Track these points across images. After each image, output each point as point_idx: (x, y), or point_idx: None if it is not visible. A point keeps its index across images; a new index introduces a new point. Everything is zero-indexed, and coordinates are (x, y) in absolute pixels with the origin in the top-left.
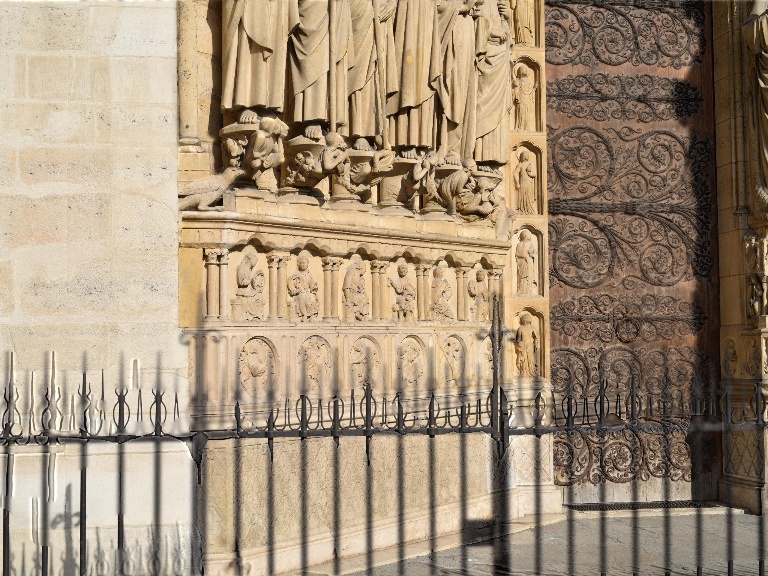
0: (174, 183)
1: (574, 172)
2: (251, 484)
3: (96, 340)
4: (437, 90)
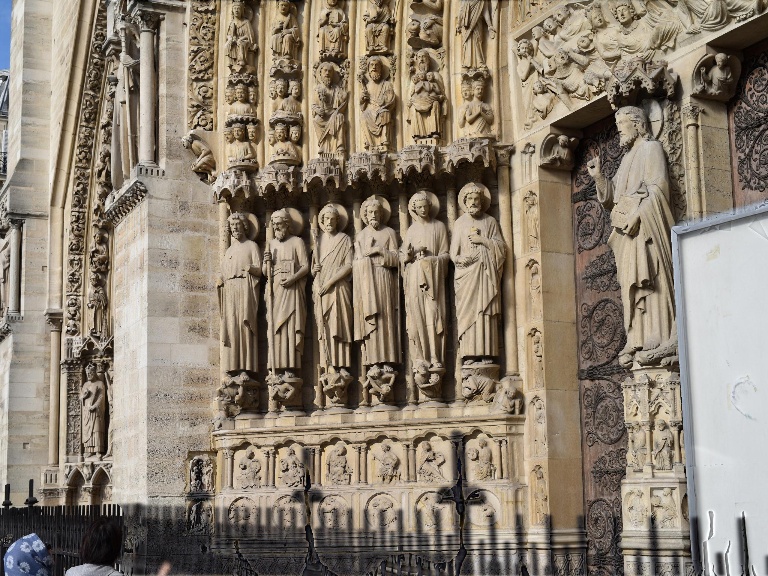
0: None
1: None
2: None
3: None
4: None
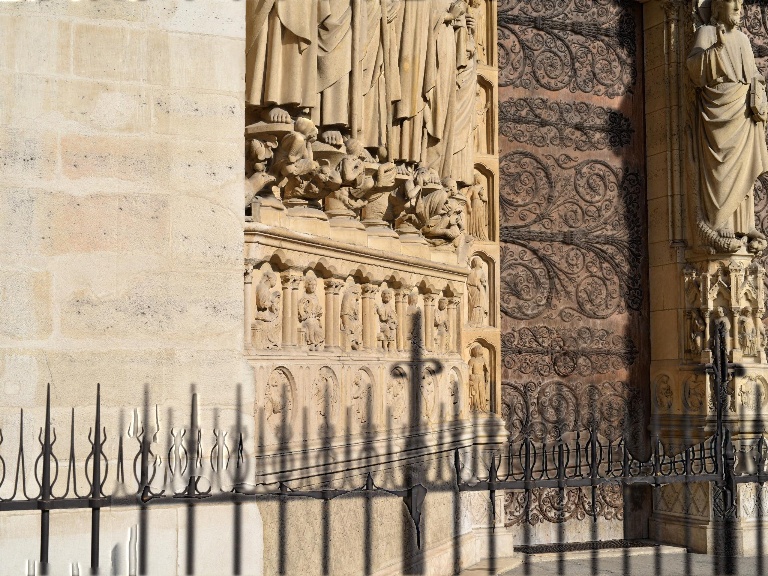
0: (241, 185)
1: (515, 198)
2: (274, 537)
3: (149, 370)
4: None
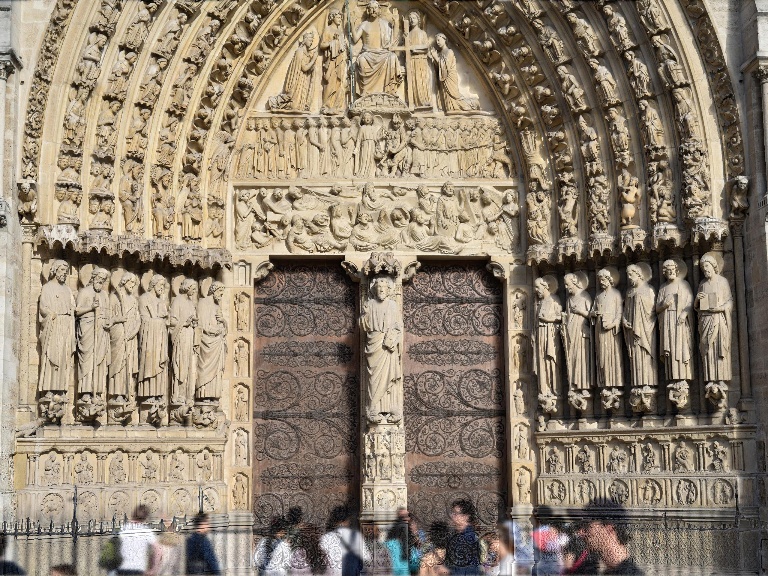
0: None
1: (278, 396)
2: (46, 560)
3: None
4: (173, 365)
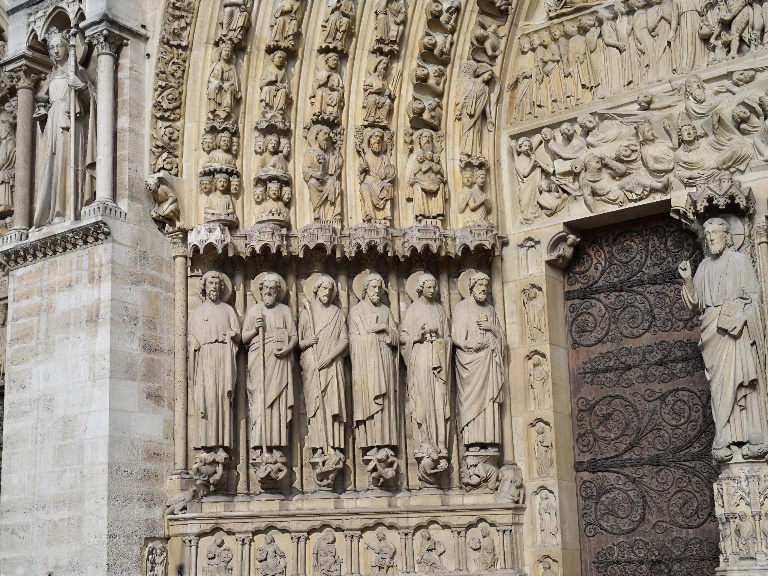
0: (106, 506)
1: (608, 434)
2: None
3: None
4: None
